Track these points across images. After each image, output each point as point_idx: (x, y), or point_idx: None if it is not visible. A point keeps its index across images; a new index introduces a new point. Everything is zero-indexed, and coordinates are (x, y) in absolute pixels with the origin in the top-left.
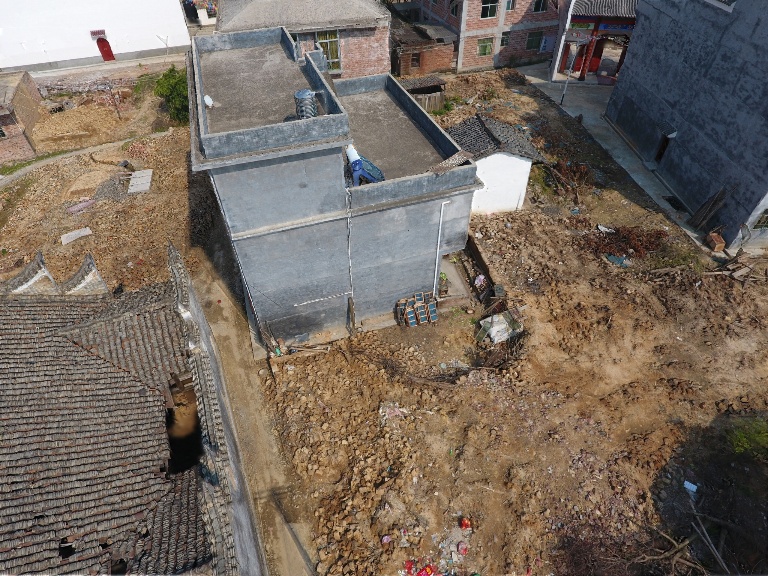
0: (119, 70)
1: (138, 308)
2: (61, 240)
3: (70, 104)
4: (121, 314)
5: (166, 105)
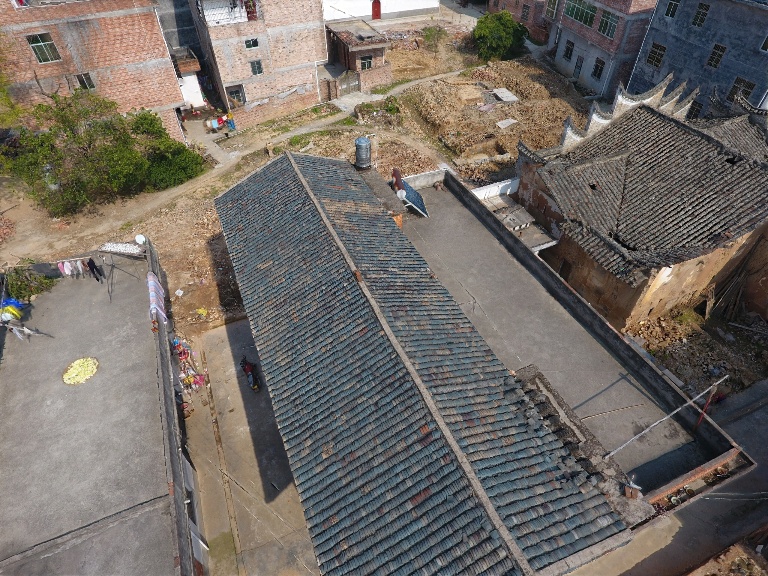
0: (391, 26)
1: (731, 120)
2: (498, 126)
3: (386, 48)
4: (723, 122)
5: (464, 48)
